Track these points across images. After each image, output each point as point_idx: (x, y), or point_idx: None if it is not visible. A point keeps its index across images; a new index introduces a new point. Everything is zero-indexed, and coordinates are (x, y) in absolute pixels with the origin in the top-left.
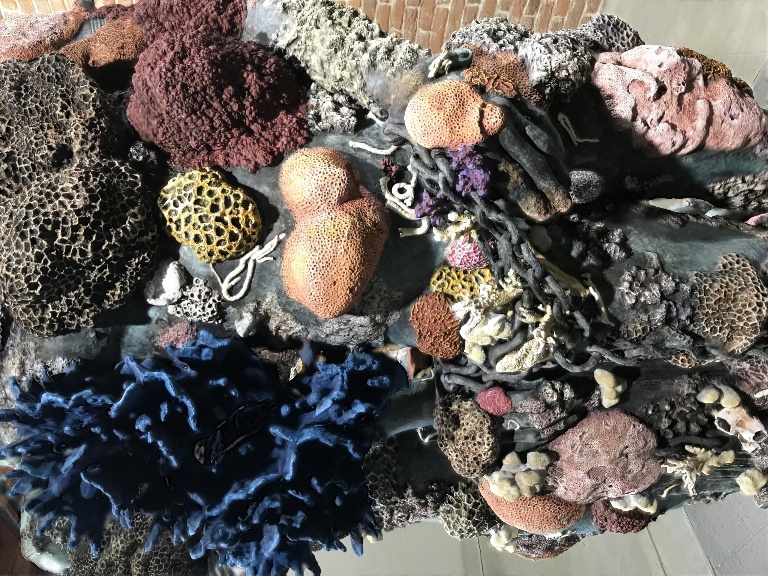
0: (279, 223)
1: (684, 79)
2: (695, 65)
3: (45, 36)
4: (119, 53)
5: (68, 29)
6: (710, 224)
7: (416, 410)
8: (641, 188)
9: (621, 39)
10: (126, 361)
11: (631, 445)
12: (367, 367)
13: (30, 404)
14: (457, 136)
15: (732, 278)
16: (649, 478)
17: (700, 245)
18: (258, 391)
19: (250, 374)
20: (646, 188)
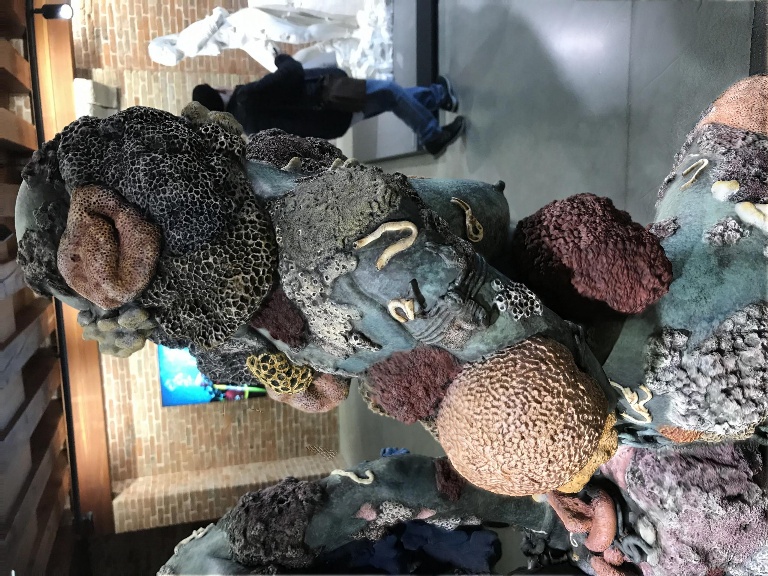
0: None
1: None
2: None
3: None
4: None
5: None
6: None
7: None
8: None
9: None
10: None
11: None
12: None
13: None
14: None
15: None
16: None
17: None
18: None
19: None
20: None
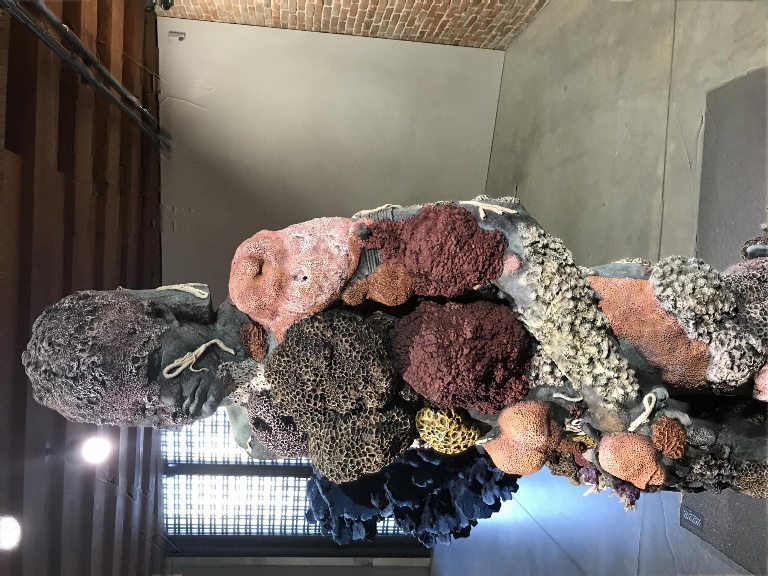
0: (490, 433)
1: None
2: None
3: (336, 287)
4: (393, 303)
5: (351, 270)
6: None
7: None
8: None
9: None
10: (385, 489)
11: None
12: None
13: (338, 516)
14: None
15: None
16: None
17: (765, 441)
18: (450, 476)
19: None
20: None
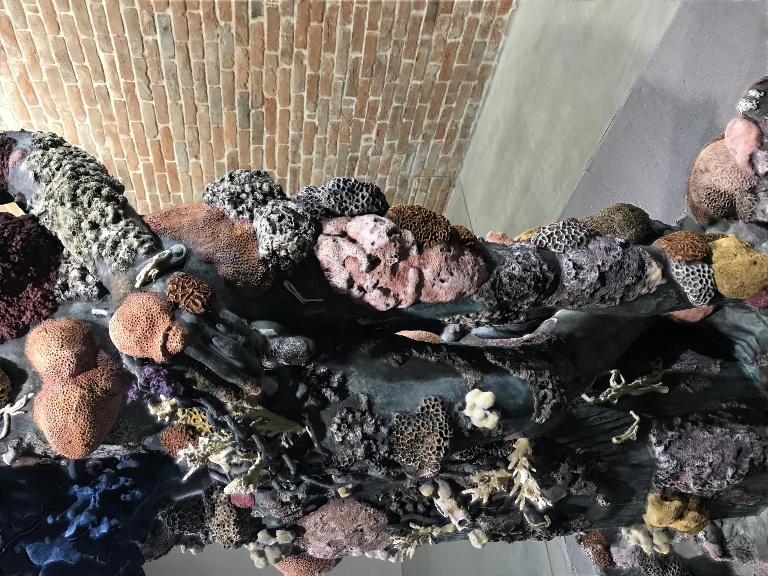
0: (28, 384)
1: (396, 253)
2: (408, 240)
3: None
4: None
5: None
6: (430, 359)
7: (197, 484)
8: (377, 322)
9: (356, 201)
10: None
11: (363, 524)
12: (119, 486)
13: None
14: (147, 353)
15: (424, 422)
16: (384, 543)
17: (411, 385)
18: (23, 510)
19: (15, 497)
20: (382, 322)
